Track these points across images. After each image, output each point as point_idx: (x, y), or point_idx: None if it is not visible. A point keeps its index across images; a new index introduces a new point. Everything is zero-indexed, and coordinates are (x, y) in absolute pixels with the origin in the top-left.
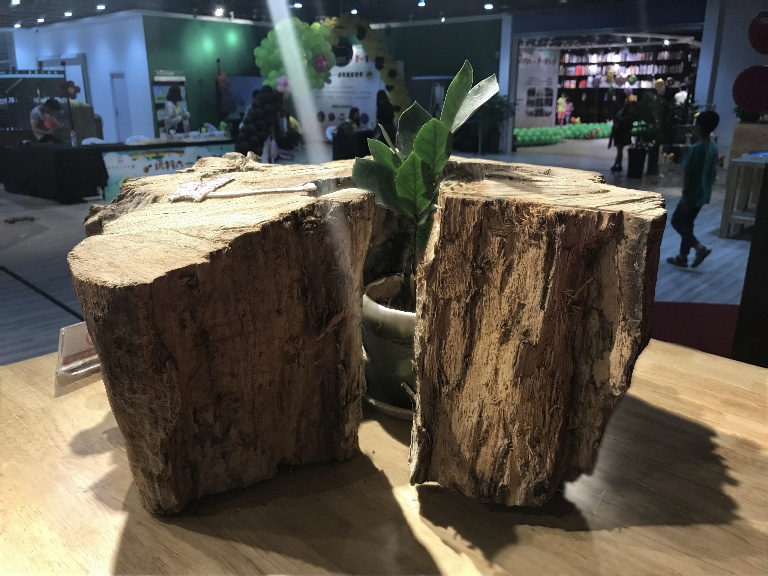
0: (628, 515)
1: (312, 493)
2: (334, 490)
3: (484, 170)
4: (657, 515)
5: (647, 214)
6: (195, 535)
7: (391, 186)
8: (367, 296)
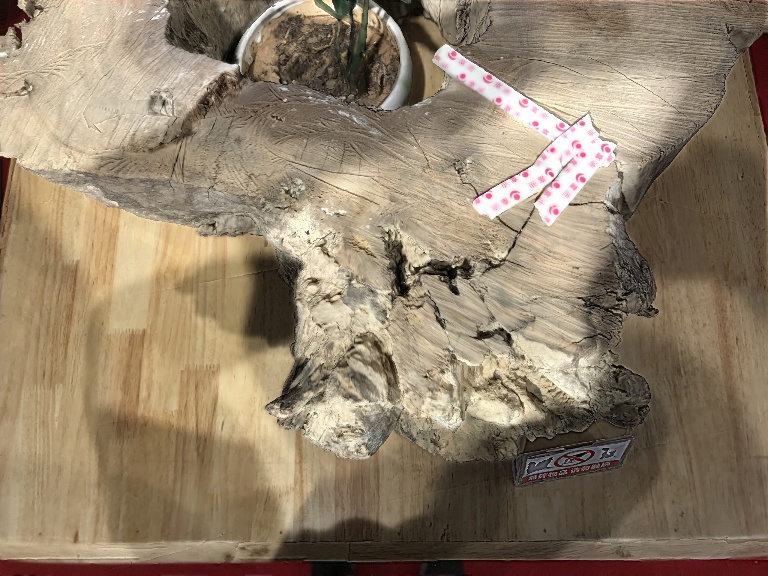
0: None
1: None
2: None
3: None
4: None
5: None
6: None
7: None
8: (392, 92)
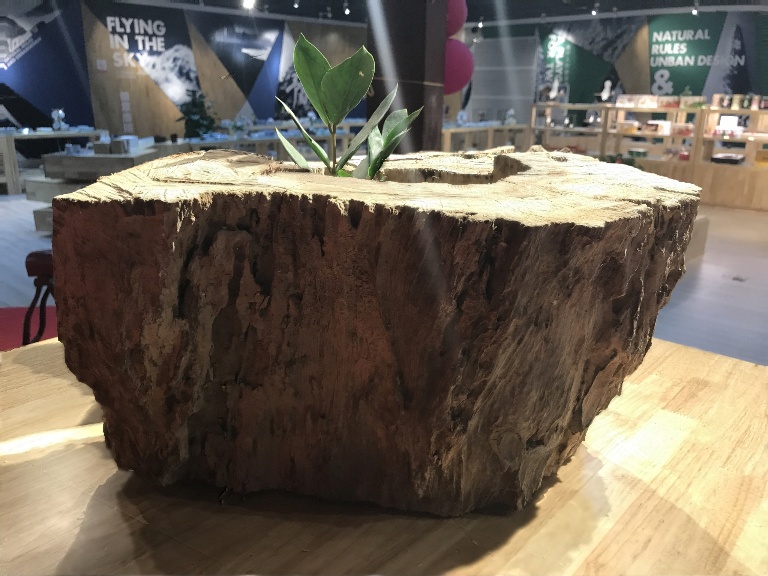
0: (98, 529)
1: None
2: None
3: None
4: (85, 552)
5: (70, 195)
6: None
7: None
8: None
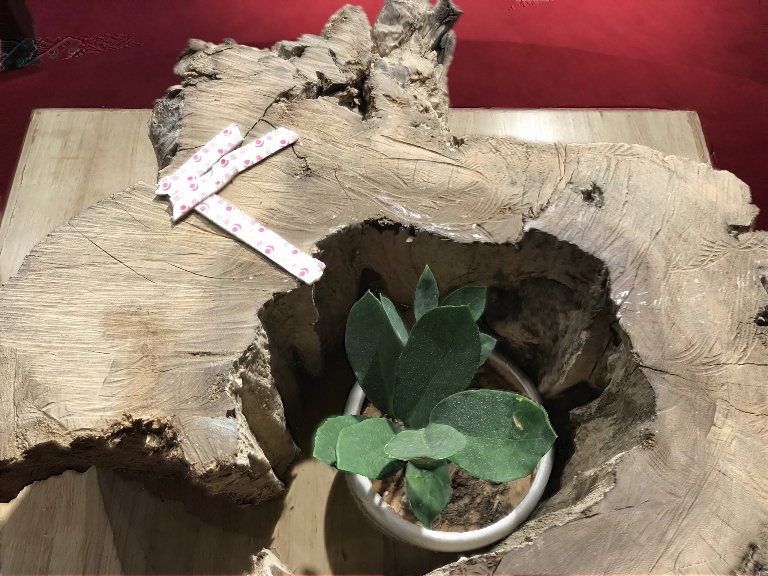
0: None
1: (200, 518)
2: (218, 529)
3: (632, 367)
4: None
5: None
6: (97, 493)
7: (391, 360)
8: None
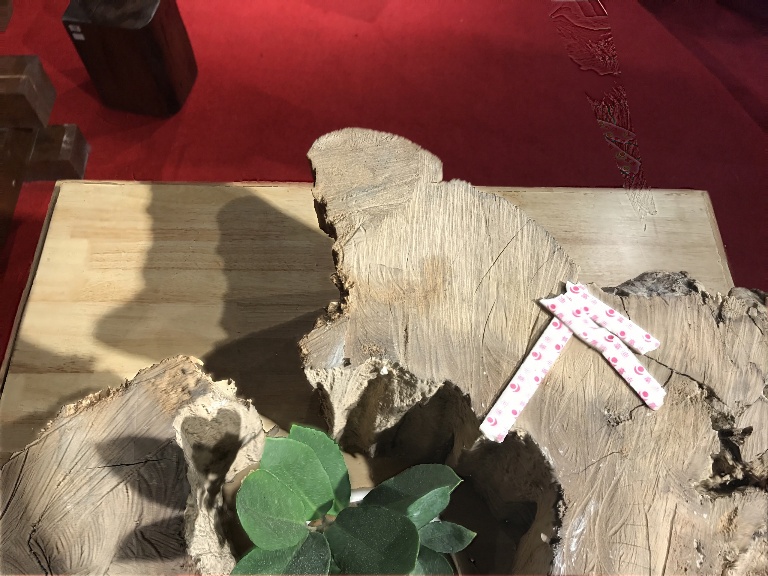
0: None
1: None
2: None
3: None
4: None
5: None
6: None
7: (400, 510)
8: None
